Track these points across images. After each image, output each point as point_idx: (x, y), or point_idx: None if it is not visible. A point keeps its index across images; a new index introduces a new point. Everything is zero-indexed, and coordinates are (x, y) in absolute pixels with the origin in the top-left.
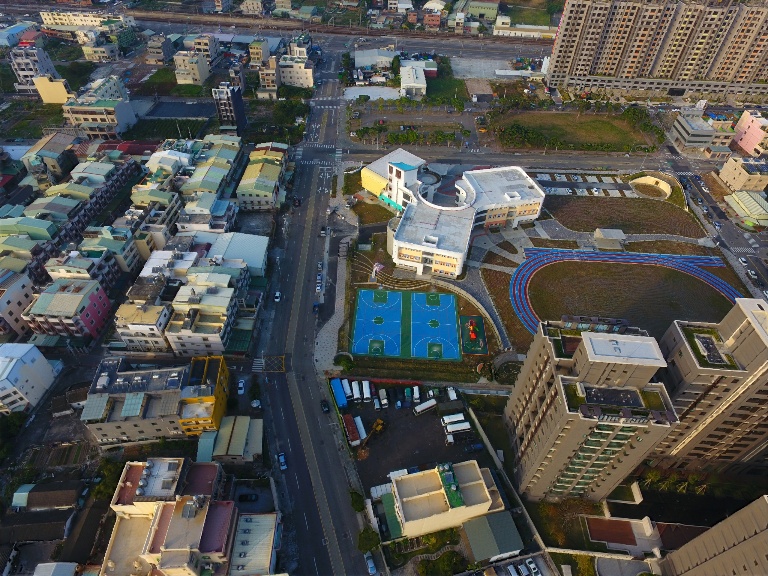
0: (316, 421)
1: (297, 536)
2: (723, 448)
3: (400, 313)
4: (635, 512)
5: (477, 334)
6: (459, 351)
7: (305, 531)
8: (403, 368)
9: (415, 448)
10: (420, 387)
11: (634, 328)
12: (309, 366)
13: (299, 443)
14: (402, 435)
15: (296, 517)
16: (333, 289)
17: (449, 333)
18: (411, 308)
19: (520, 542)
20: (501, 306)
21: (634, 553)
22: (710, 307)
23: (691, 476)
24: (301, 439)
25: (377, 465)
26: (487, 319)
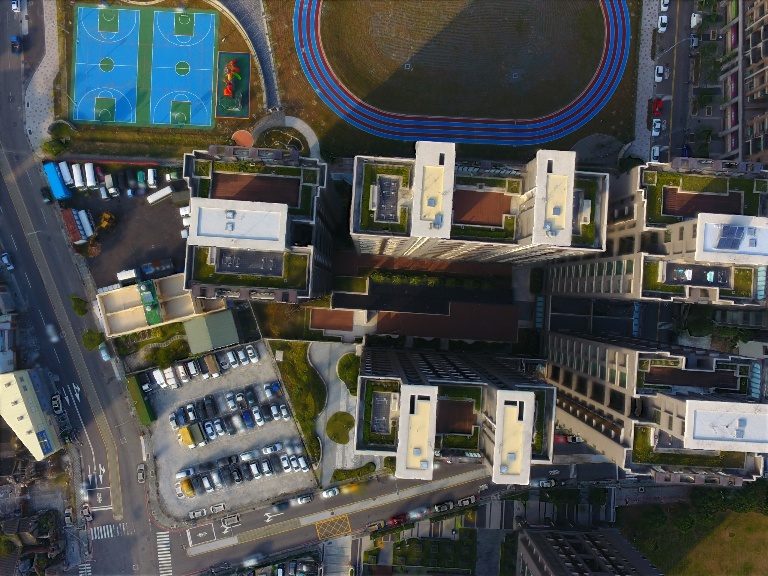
0: (39, 214)
1: (35, 331)
2: (449, 257)
3: (136, 51)
4: (362, 302)
5: (238, 85)
6: (211, 113)
7: (42, 327)
8: (140, 140)
9: (151, 242)
10: (157, 168)
11: (312, 159)
12: (22, 140)
13: (23, 240)
14: (137, 228)
15: (32, 315)
16: (39, 6)
17: (201, 84)
18: (152, 41)
19: (235, 337)
20: (277, 35)
21: (347, 338)
22: (571, 29)
23: (433, 266)
24: (25, 236)
25: (110, 262)
26: (255, 59)
